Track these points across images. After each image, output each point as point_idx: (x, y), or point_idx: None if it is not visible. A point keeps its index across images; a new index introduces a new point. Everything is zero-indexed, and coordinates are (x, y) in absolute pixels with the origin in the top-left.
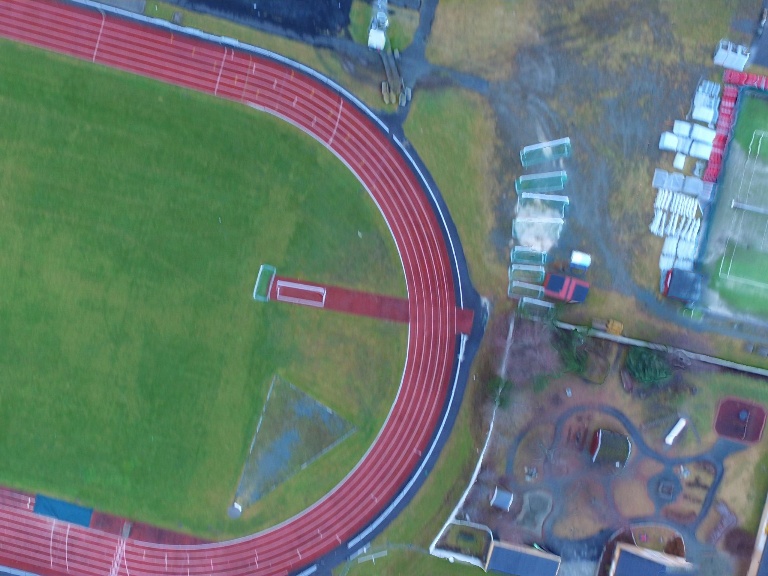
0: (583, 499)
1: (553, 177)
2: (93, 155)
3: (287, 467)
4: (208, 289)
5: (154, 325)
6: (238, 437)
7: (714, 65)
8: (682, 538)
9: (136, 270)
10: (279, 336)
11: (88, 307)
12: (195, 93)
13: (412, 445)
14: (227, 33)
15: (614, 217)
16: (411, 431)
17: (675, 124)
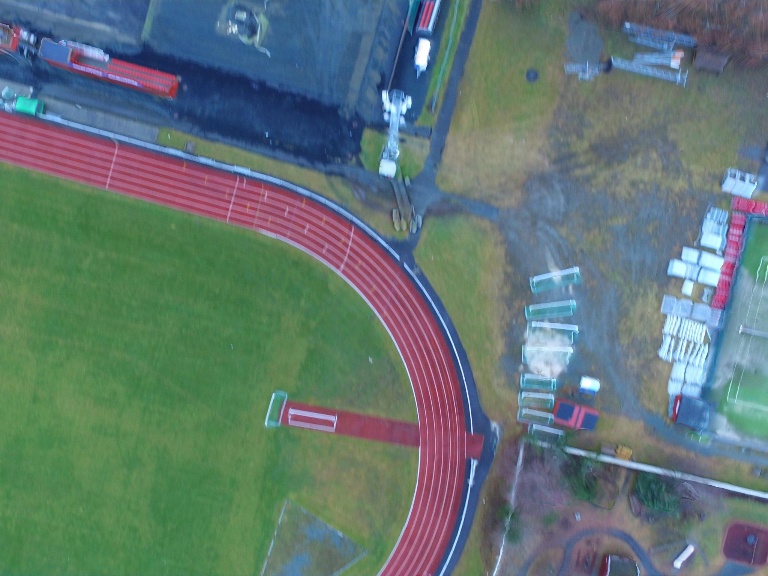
0: None
1: (563, 306)
2: (106, 282)
3: None
4: (220, 414)
5: (166, 450)
6: (250, 561)
7: (722, 192)
8: None
9: (149, 396)
10: (290, 461)
11: (101, 432)
12: (207, 220)
13: (422, 568)
14: (239, 161)
15: (623, 342)
16: (421, 554)
17: (683, 251)
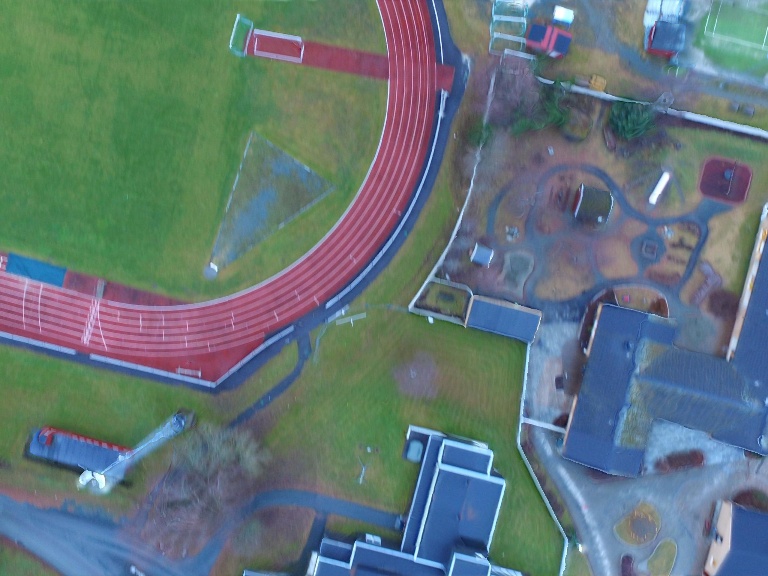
0: (565, 258)
1: None
2: None
3: (264, 227)
4: (184, 43)
5: (129, 80)
6: (214, 195)
7: None
8: (666, 299)
9: (111, 23)
10: (256, 92)
11: (62, 61)
12: None
13: (391, 205)
14: None
15: None
16: (390, 191)
17: None
